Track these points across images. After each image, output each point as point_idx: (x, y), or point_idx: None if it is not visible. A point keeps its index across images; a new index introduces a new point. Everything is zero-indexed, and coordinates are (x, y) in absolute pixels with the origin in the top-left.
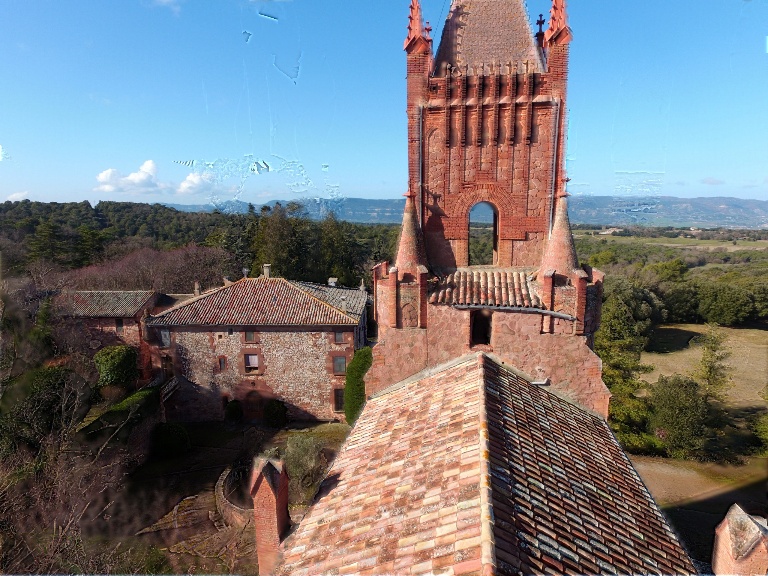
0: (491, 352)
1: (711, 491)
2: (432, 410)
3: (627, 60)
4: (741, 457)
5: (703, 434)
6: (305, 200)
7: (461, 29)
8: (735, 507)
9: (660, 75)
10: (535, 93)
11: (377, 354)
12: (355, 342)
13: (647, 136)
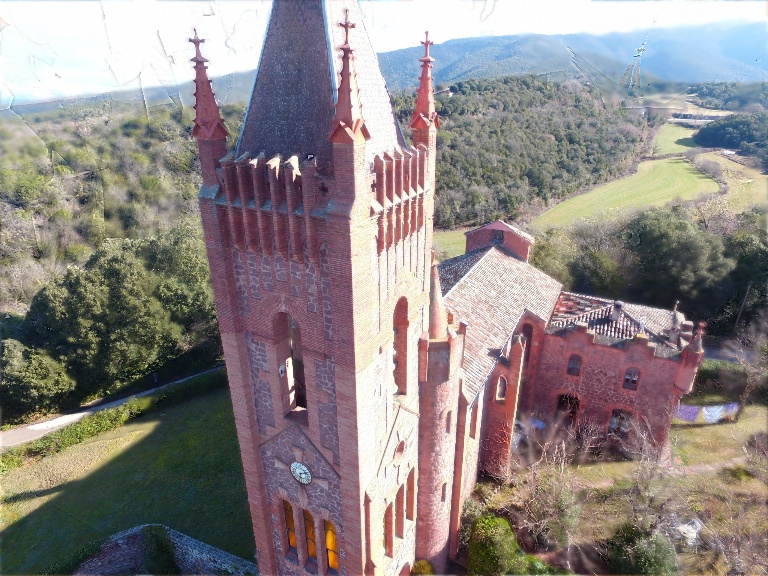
0: None
1: None
2: None
3: None
4: None
5: None
6: None
7: None
8: None
9: None
10: None
11: None
12: None
13: None
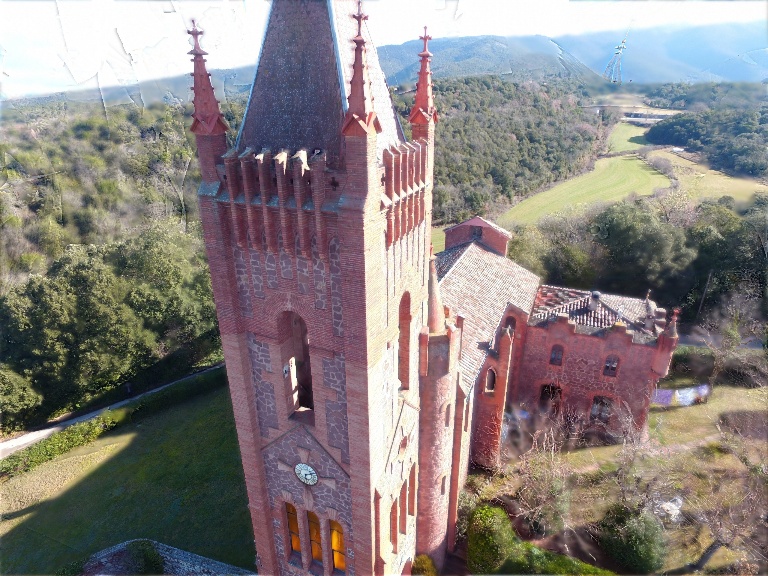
0: None
1: None
2: None
3: None
4: None
5: None
6: None
7: None
8: None
9: None
10: None
11: None
12: None
13: None
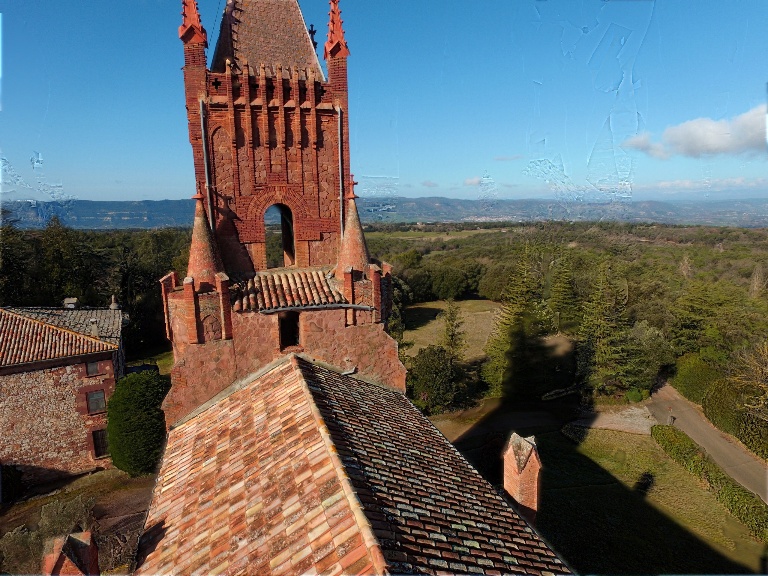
0: (302, 352)
1: (463, 434)
2: (257, 422)
3: (361, 77)
4: (478, 401)
5: (453, 390)
6: (13, 203)
7: (235, 25)
8: (514, 435)
9: (388, 94)
10: (317, 100)
11: (177, 376)
12: (114, 371)
13: (383, 146)
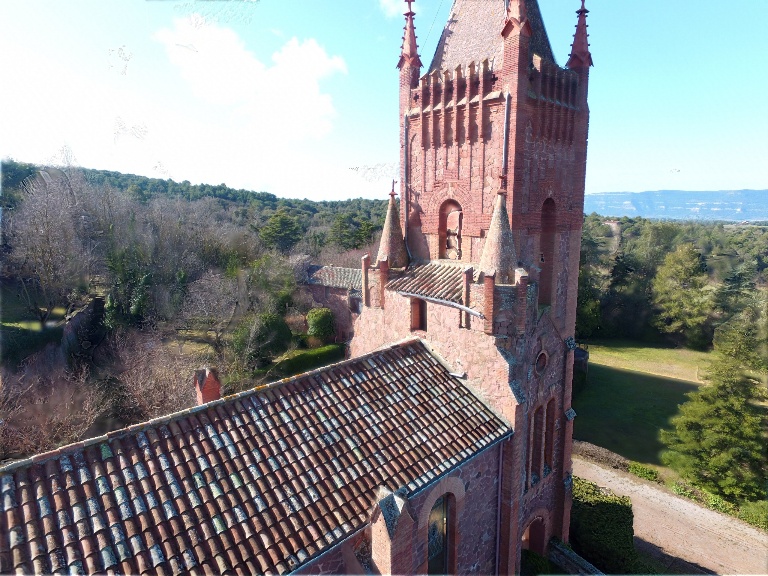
0: (424, 338)
1: None
2: None
3: None
4: None
5: None
6: None
7: (448, 37)
8: None
9: None
10: (487, 91)
11: (357, 326)
12: None
13: None
